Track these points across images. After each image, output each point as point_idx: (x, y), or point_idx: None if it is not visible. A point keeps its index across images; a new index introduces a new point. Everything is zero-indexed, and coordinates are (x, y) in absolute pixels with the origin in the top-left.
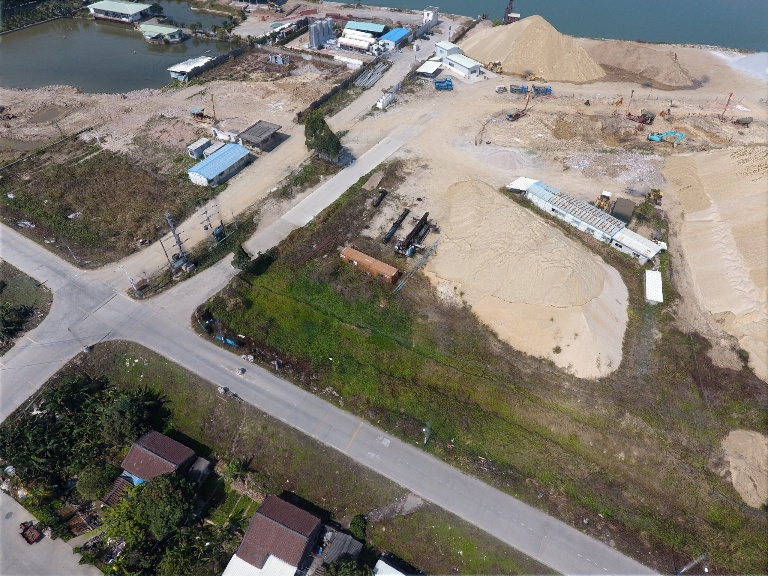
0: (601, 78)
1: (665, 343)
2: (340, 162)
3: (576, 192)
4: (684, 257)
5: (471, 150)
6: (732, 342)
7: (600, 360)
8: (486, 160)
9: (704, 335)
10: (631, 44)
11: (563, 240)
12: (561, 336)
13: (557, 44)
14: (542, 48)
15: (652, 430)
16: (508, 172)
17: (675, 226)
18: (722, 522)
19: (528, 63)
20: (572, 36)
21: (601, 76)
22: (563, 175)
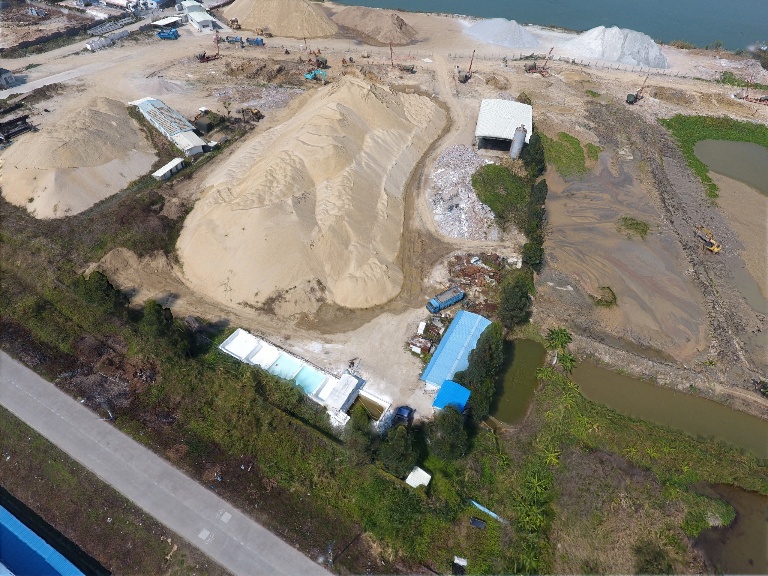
0: (327, 35)
1: (125, 199)
2: (8, 85)
3: (195, 111)
4: (232, 154)
5: (138, 81)
6: (184, 201)
7: (58, 206)
8: (142, 88)
9: (166, 196)
10: (366, 8)
11: (127, 137)
12: (37, 190)
13: (287, 4)
14: (275, 8)
15: (50, 246)
16: (152, 96)
17: (252, 135)
18: (49, 298)
19: (262, 21)
20: (342, 5)
21: (328, 34)
22: (199, 100)
